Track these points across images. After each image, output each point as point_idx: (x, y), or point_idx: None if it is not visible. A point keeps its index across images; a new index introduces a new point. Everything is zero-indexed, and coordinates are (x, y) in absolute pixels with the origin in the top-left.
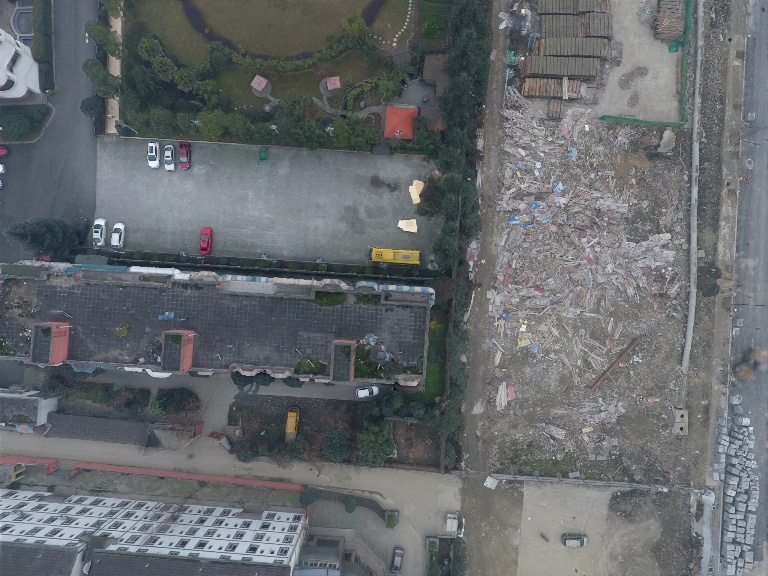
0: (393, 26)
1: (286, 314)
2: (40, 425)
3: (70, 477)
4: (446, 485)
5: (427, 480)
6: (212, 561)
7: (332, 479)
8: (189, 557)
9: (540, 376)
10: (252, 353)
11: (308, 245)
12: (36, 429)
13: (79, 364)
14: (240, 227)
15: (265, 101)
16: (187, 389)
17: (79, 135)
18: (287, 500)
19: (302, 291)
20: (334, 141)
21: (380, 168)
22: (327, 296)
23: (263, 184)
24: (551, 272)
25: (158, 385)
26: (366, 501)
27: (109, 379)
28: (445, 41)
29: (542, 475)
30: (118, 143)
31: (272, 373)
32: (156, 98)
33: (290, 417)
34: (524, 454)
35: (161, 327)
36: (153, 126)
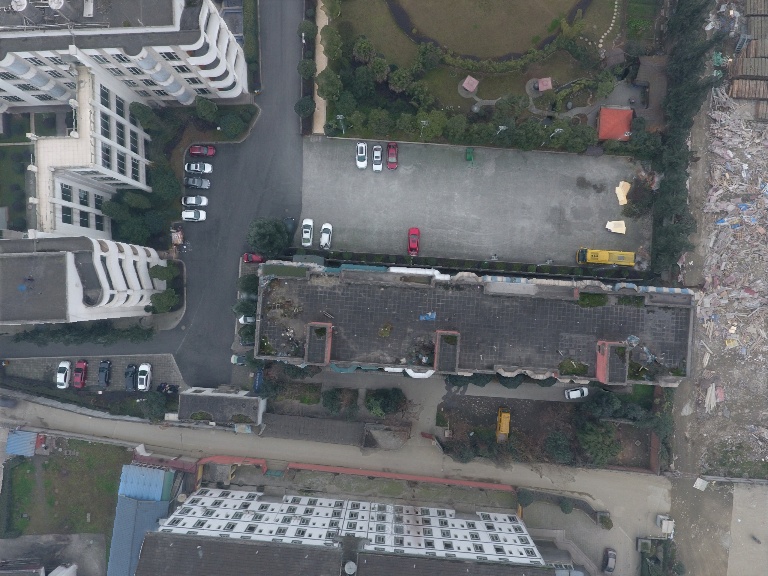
0: (599, 27)
1: (548, 315)
2: (258, 425)
3: (279, 477)
4: (656, 486)
5: (637, 481)
6: (477, 562)
7: (557, 480)
8: (454, 558)
9: (748, 378)
10: (514, 354)
11: (514, 246)
12: (253, 429)
13: (341, 364)
14: (446, 228)
15: (471, 102)
16: (400, 389)
17: (285, 135)
18: (496, 501)
19: (563, 292)
20: (553, 142)
21: (586, 169)
22: (589, 297)
23: (469, 185)
24: (758, 274)
25: (366, 385)
26: (578, 502)
27: (317, 379)
28: (651, 42)
29: (751, 477)
30: (324, 143)
31: (533, 374)
32: (366, 98)
33: (505, 418)
34: (733, 456)
35: (423, 328)
36: (372, 126)
